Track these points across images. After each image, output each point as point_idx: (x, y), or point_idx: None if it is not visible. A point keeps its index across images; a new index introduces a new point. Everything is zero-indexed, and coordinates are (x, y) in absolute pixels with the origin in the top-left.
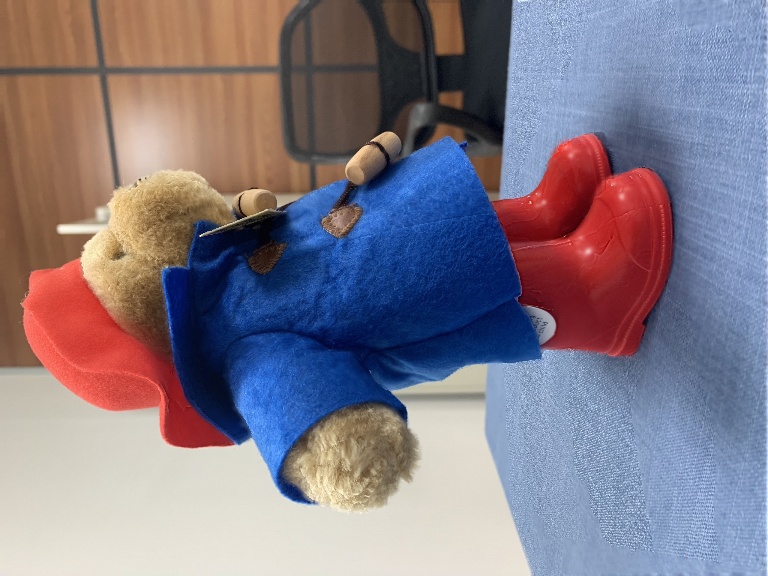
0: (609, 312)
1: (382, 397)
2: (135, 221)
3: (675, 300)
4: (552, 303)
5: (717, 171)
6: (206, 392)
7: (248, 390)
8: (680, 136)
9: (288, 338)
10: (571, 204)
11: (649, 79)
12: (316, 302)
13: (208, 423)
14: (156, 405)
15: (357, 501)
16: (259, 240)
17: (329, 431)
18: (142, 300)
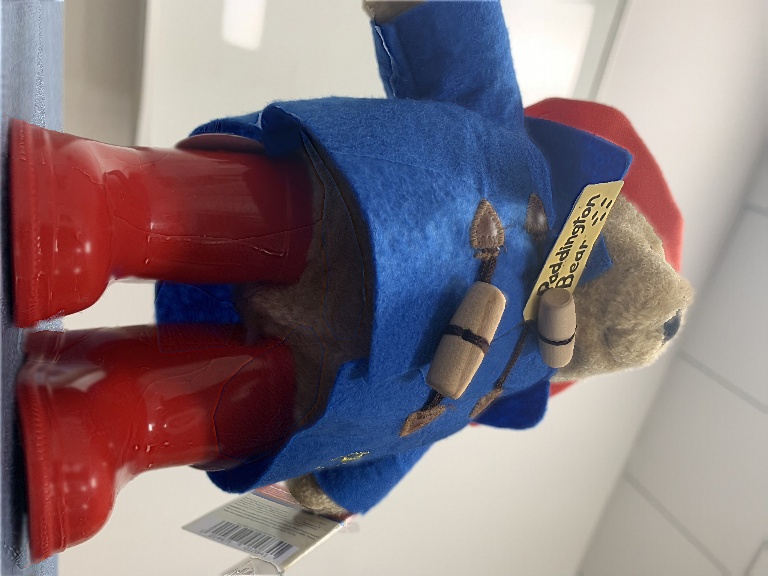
0: None
1: (418, 11)
2: None
3: None
4: (191, 146)
5: None
6: None
7: None
8: None
9: (497, 116)
10: (91, 388)
11: None
12: (489, 131)
13: None
14: None
15: None
16: (543, 259)
17: None
18: None
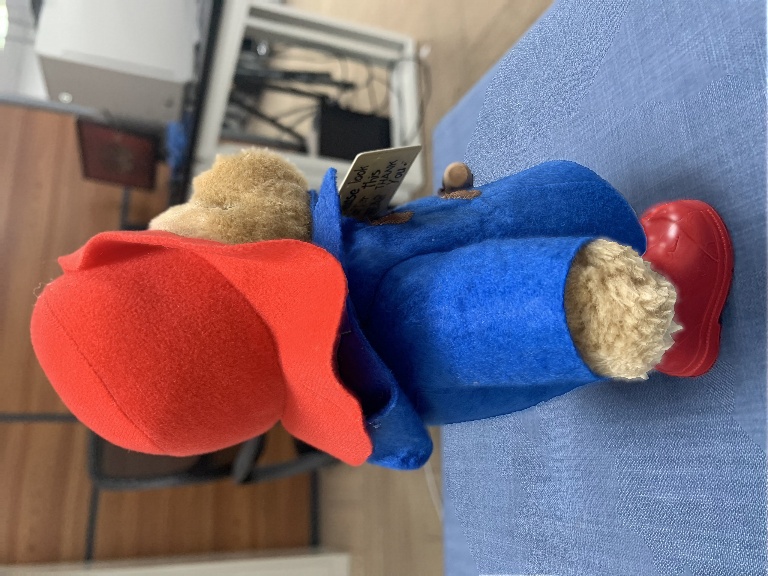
0: (691, 309)
1: None
2: (249, 174)
3: (753, 274)
4: None
5: (759, 153)
6: (361, 323)
7: (452, 273)
8: (703, 162)
9: None
10: None
11: (646, 154)
12: (481, 226)
13: (349, 380)
14: (214, 430)
15: (658, 319)
16: None
17: (605, 245)
18: (265, 236)
